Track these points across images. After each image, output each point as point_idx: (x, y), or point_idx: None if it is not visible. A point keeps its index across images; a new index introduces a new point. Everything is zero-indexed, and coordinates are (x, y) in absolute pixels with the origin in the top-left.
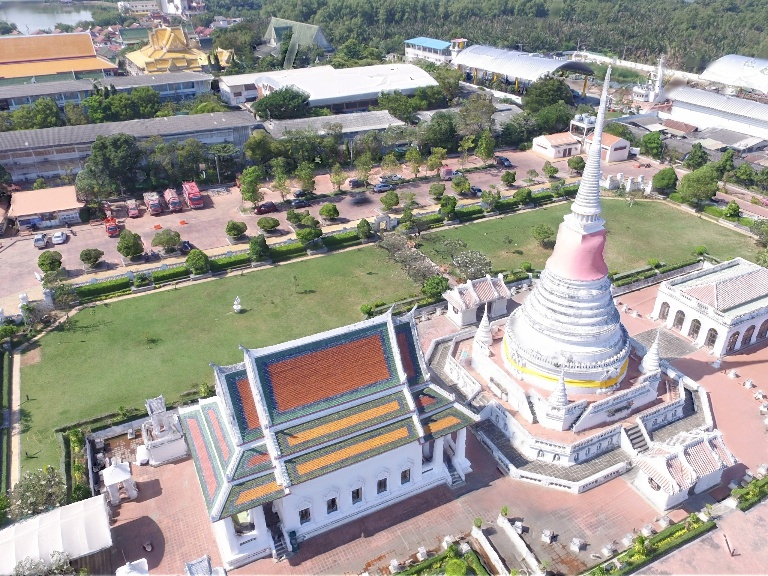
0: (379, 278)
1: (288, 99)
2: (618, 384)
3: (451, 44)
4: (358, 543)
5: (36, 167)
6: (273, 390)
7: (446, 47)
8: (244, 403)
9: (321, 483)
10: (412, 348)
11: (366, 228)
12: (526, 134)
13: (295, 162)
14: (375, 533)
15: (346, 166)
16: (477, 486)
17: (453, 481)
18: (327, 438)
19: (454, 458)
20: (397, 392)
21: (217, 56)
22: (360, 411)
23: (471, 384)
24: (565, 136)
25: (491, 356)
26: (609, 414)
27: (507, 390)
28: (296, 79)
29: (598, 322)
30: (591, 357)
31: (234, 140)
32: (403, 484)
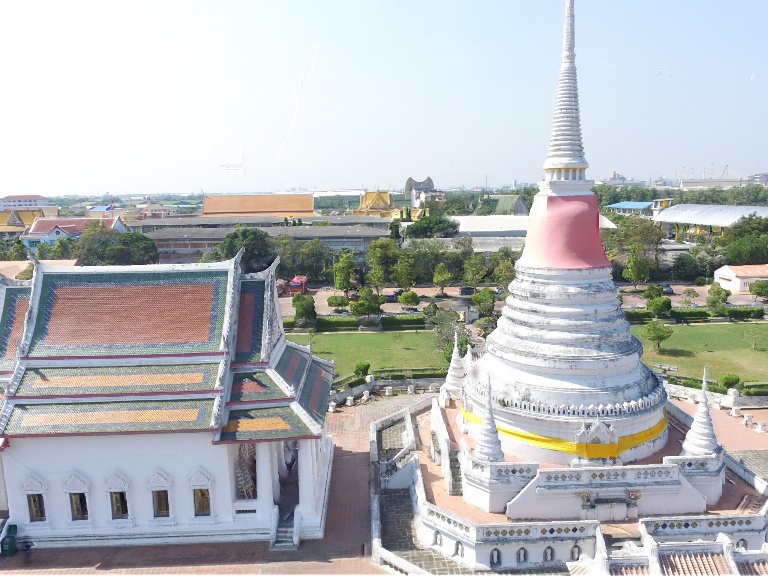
0: (414, 353)
1: (434, 223)
2: (618, 460)
3: (653, 203)
4: (80, 572)
5: (189, 257)
6: (51, 318)
7: (647, 206)
8: (15, 327)
9: (61, 458)
10: (259, 315)
11: (430, 310)
12: (709, 269)
13: (394, 255)
14: (113, 568)
15: (453, 268)
16: (309, 557)
17: (279, 539)
18: (83, 391)
19: (296, 506)
20: (211, 363)
21: (410, 211)
22: (147, 372)
23: (409, 441)
24: (760, 268)
25: (449, 407)
26: (583, 502)
27: (439, 444)
28: (459, 217)
29: (579, 341)
30: (561, 397)
31: (364, 250)
32: (198, 516)
